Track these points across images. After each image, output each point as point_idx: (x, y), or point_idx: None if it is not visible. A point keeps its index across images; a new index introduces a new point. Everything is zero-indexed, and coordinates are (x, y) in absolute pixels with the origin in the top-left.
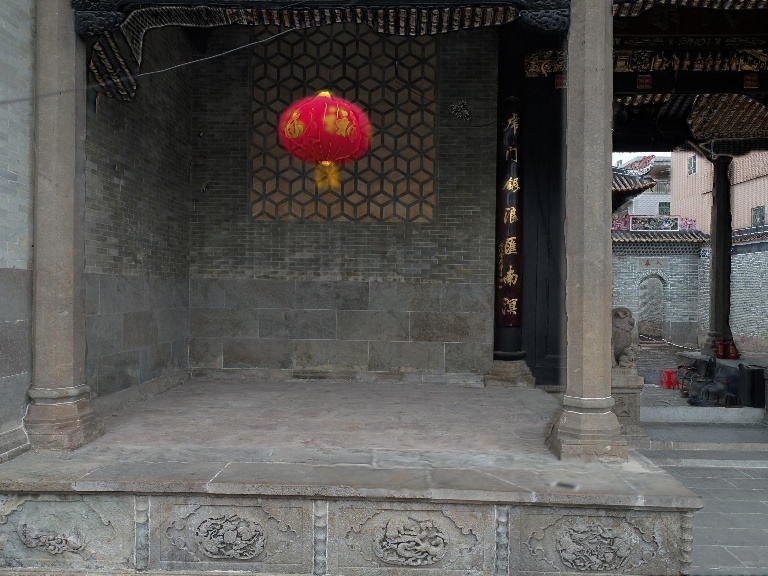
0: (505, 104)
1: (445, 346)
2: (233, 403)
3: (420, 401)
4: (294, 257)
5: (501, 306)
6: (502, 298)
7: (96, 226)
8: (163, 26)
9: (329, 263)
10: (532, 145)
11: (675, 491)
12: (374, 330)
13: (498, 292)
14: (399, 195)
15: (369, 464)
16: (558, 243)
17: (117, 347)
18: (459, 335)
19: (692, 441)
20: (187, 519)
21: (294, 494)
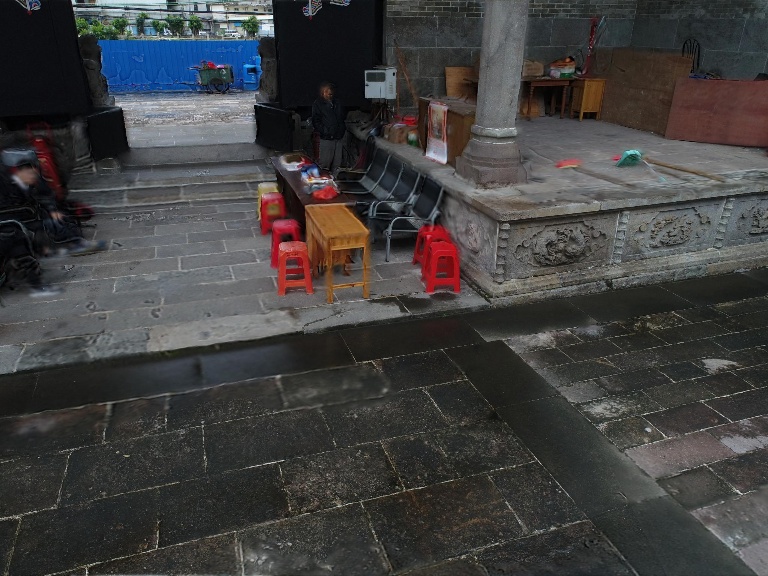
0: None
1: None
2: None
3: None
4: None
5: None
6: None
7: None
8: None
9: None
10: None
11: None
12: None
13: None
14: None
15: None
16: None
17: None
18: None
19: None
20: None
21: None
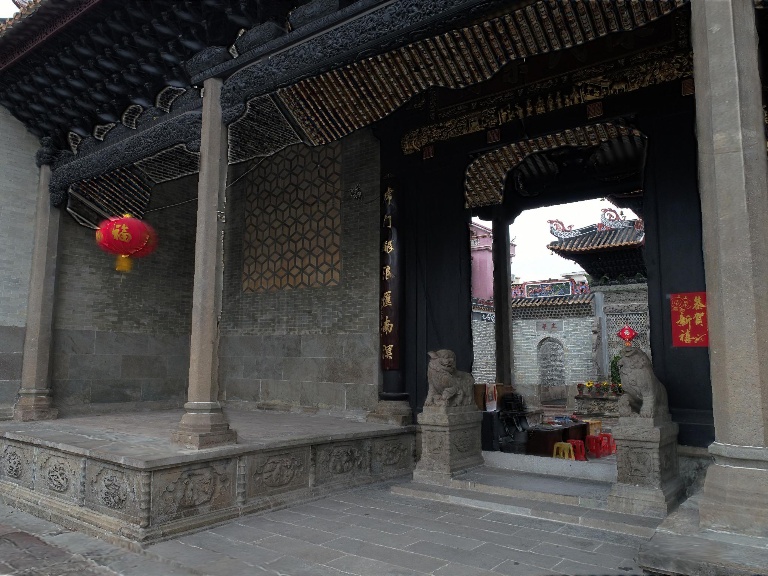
0: (384, 181)
1: (346, 387)
2: (167, 415)
3: (270, 423)
4: (262, 318)
5: (382, 352)
6: (382, 345)
7: (93, 303)
8: (179, 177)
9: (280, 321)
10: (411, 210)
11: (147, 458)
12: (304, 373)
13: (381, 340)
14: (319, 265)
15: (88, 436)
16: (434, 294)
17: (114, 375)
18: (355, 377)
19: (489, 484)
20: (5, 452)
21: (26, 441)
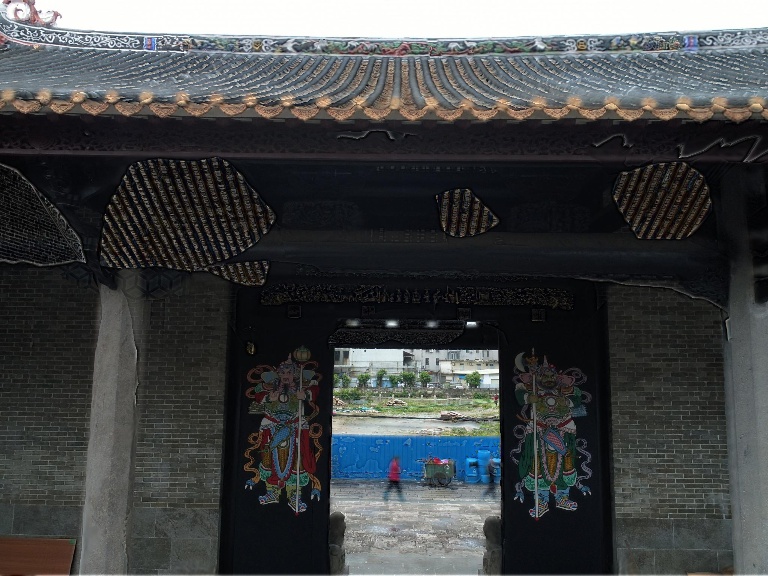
0: None
1: None
2: None
3: None
4: None
5: None
6: None
7: None
8: None
9: None
10: None
11: None
12: None
13: None
14: None
15: None
16: None
17: None
18: None
19: None
20: None
21: None
